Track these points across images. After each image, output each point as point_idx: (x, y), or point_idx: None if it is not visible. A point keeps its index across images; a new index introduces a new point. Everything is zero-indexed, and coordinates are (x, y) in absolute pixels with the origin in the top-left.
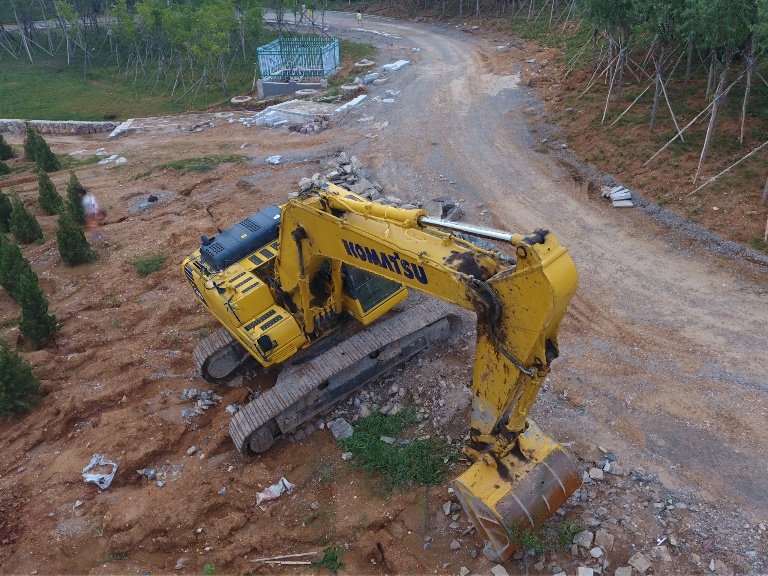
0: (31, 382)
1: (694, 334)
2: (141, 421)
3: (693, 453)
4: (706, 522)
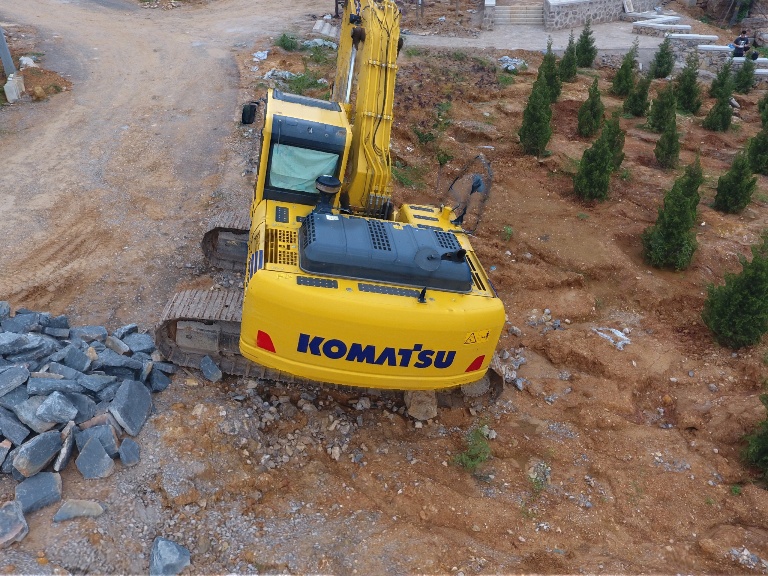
0: (762, 441)
1: (44, 203)
2: (573, 346)
3: (202, 165)
4: (249, 151)
